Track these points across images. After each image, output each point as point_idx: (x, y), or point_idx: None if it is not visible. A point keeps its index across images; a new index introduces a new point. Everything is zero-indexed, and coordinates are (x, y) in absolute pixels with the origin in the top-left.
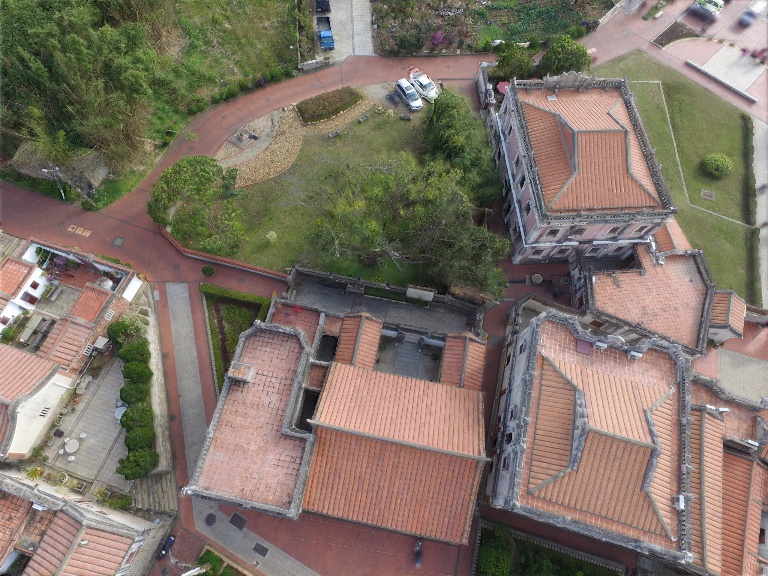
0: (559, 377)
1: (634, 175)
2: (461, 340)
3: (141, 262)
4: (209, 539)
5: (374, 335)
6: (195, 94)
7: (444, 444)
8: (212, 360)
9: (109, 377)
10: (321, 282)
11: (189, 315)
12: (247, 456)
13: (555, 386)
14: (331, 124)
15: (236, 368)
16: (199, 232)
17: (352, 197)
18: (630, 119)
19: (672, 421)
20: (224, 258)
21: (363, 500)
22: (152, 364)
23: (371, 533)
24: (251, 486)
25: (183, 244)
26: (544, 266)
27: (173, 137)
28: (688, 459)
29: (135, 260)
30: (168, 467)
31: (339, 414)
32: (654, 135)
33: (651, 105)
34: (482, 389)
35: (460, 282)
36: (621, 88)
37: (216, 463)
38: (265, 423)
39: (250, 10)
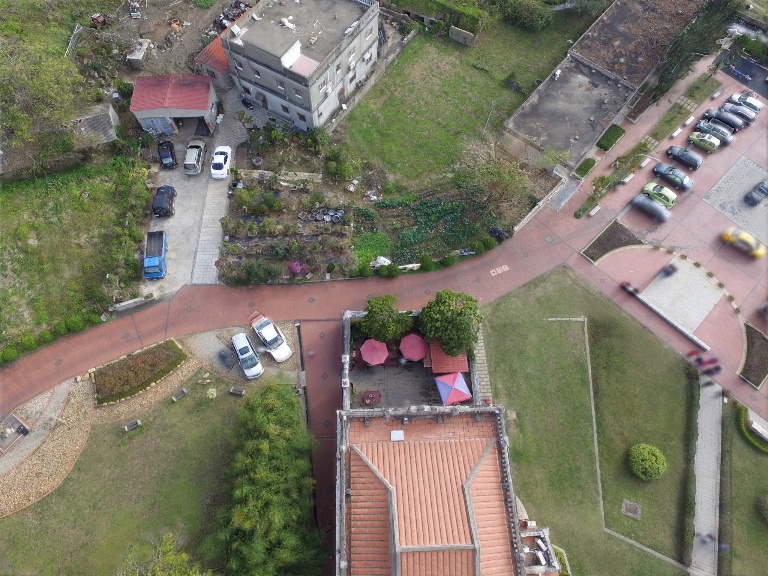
0: None
1: None
2: None
3: None
4: None
5: None
6: None
7: None
8: None
9: None
10: None
11: None
12: None
13: None
14: (135, 403)
15: None
16: None
17: None
18: (502, 477)
19: None
20: None
21: None
22: None
23: None
24: None
25: None
26: None
27: None
28: None
29: None
30: None
31: None
32: (568, 410)
33: (569, 359)
34: None
35: None
36: (497, 418)
37: None
38: None
39: (68, 216)
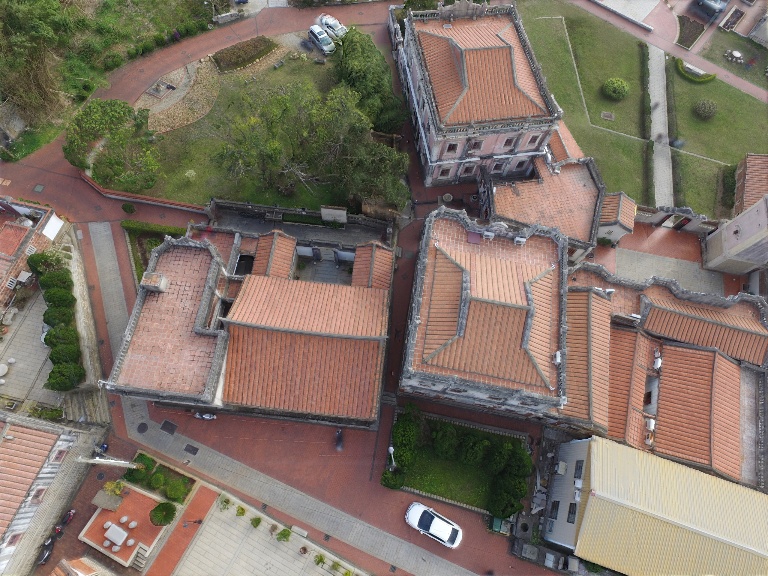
0: (449, 263)
1: (521, 88)
2: (369, 248)
3: (63, 205)
4: (141, 445)
5: (288, 250)
6: (111, 50)
7: (349, 332)
8: (137, 288)
9: (35, 308)
10: (242, 214)
11: (113, 250)
12: (164, 355)
13: (446, 271)
14: (248, 72)
15: (148, 277)
16: (116, 171)
17: (253, 119)
18: (520, 41)
19: (552, 293)
20: (144, 196)
21: (278, 389)
22: (76, 293)
23: (295, 427)
24: (168, 380)
25: (104, 187)
26: (455, 187)
27: (91, 92)
28: (564, 321)
29: (56, 204)
30: (97, 384)
31: (251, 315)
32: (557, 65)
33: (554, 38)
34: (398, 298)
35: (364, 195)
36: (512, 14)
37: (134, 363)
38: (180, 326)
39: None
